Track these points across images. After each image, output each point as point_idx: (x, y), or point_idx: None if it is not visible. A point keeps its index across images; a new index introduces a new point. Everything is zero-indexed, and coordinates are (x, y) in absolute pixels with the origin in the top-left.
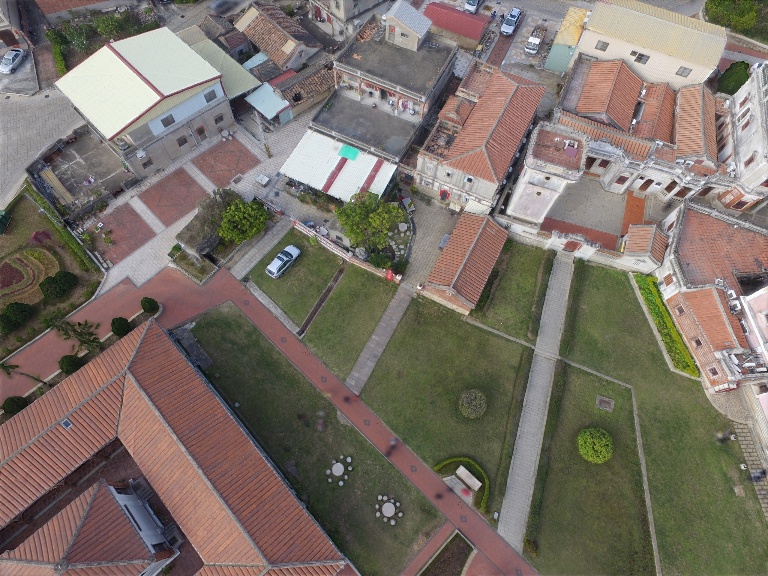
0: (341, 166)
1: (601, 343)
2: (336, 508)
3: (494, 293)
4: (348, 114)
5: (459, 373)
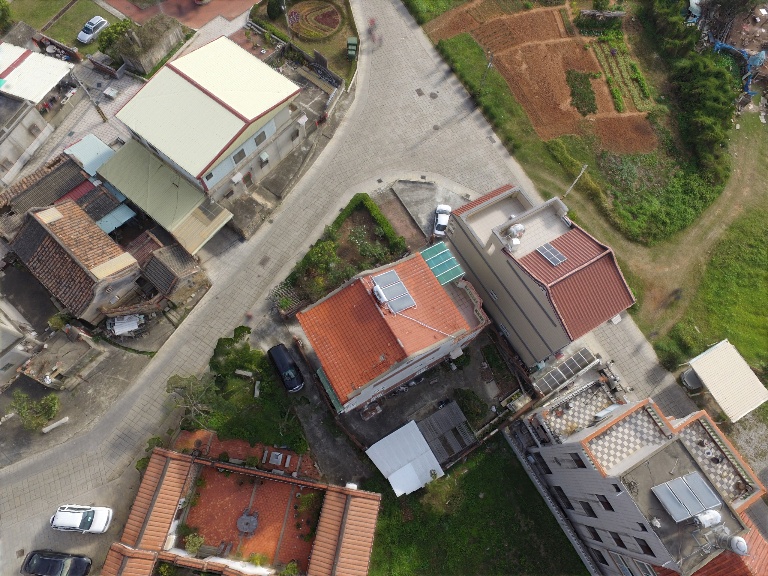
0: (6, 71)
1: None
2: None
3: None
4: None
5: None
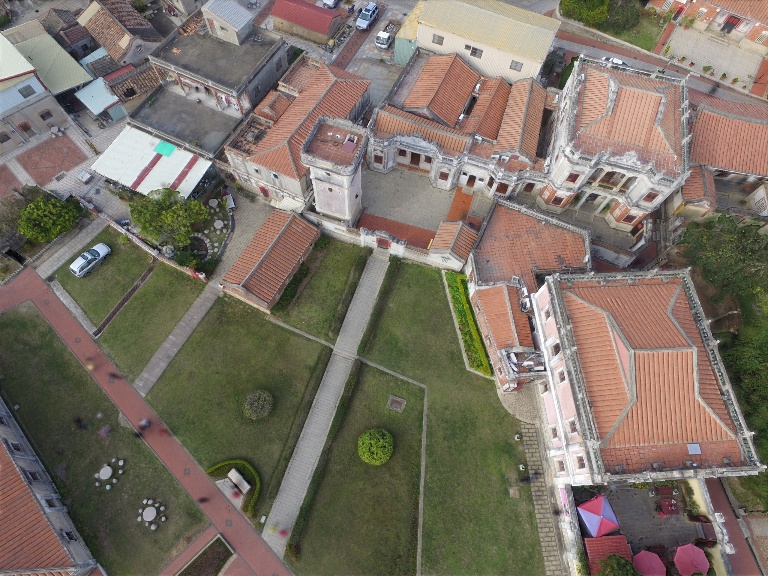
0: (155, 162)
1: (402, 342)
2: (99, 512)
3: (302, 291)
4: (171, 109)
5: (253, 373)
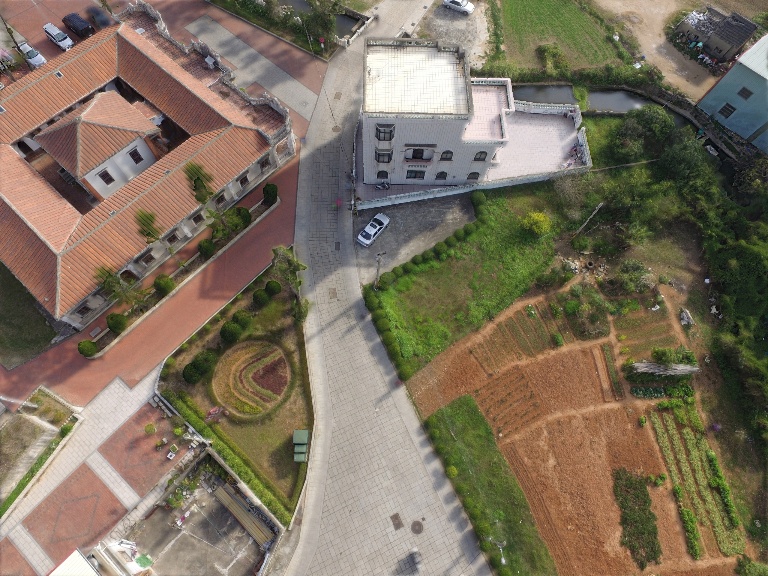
0: None
1: None
2: None
3: None
4: None
5: None
